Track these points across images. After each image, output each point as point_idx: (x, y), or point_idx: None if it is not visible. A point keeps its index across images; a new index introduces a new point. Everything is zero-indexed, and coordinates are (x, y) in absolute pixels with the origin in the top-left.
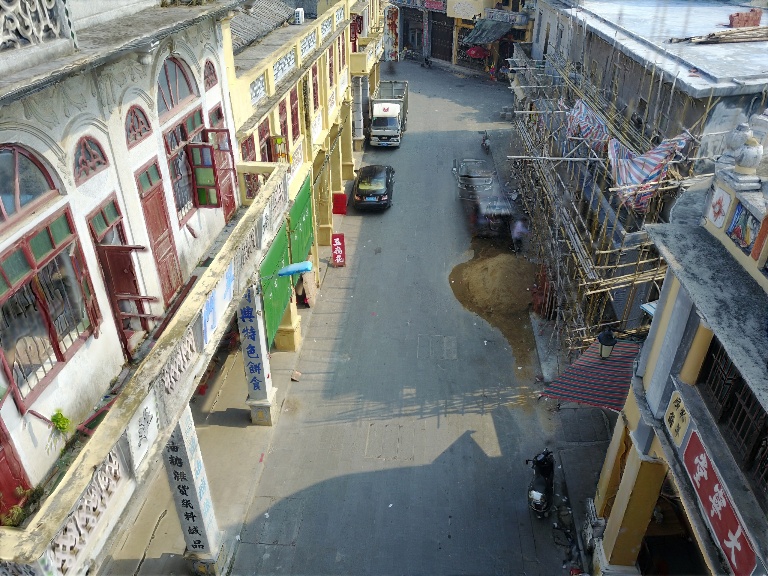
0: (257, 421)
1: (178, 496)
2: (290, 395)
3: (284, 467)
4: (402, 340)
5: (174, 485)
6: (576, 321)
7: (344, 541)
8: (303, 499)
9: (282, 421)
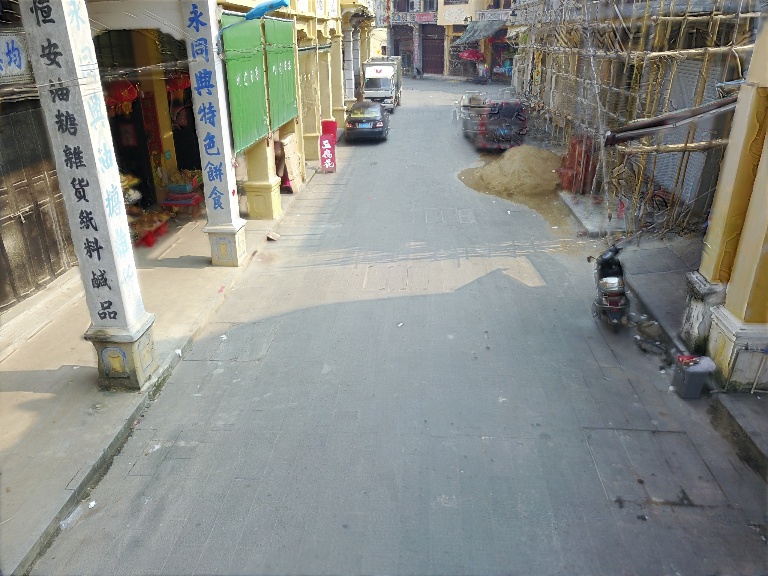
0: (219, 261)
1: (73, 204)
2: (265, 250)
3: (252, 299)
4: (406, 212)
5: (66, 179)
6: (627, 142)
7: (334, 354)
8: (276, 322)
9: (252, 267)
